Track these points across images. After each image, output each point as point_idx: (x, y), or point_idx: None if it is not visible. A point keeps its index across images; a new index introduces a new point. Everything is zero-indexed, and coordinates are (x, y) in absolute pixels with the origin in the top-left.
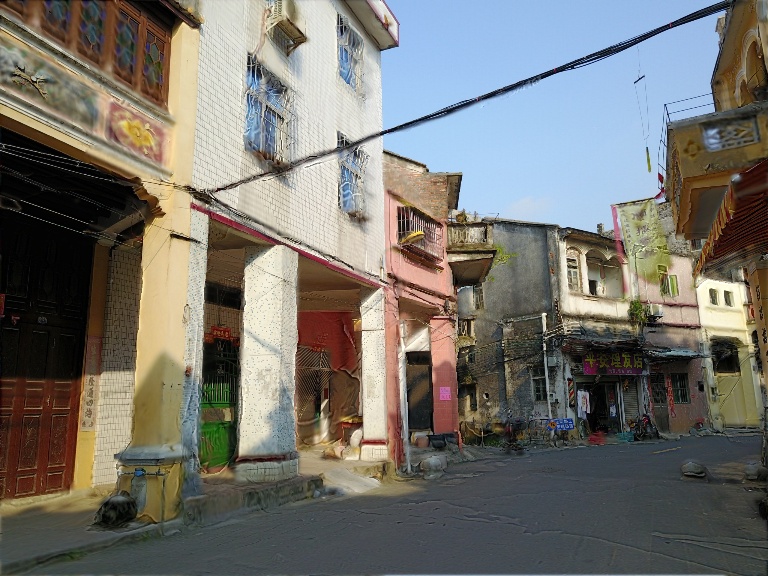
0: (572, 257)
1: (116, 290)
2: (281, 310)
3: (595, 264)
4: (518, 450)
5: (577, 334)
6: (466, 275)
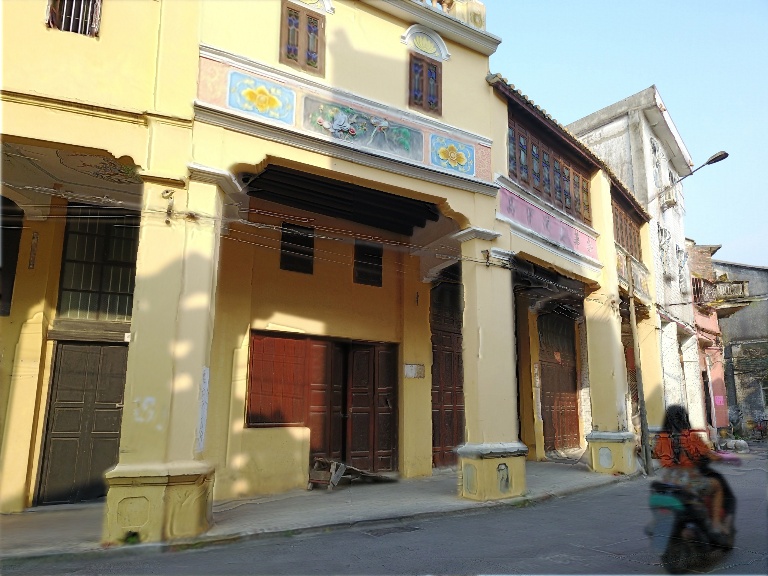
0: None
1: (582, 346)
2: (677, 357)
3: None
4: (760, 442)
5: None
6: None
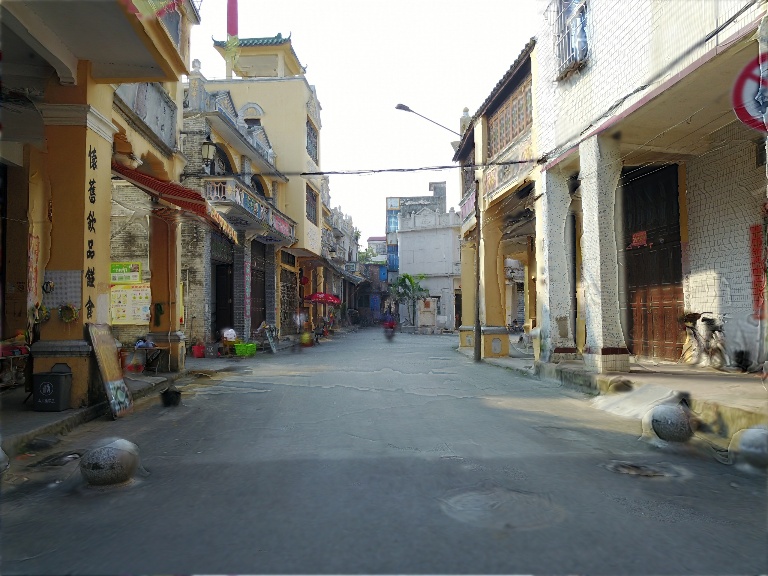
0: None
1: None
2: None
3: None
4: None
5: None
6: None
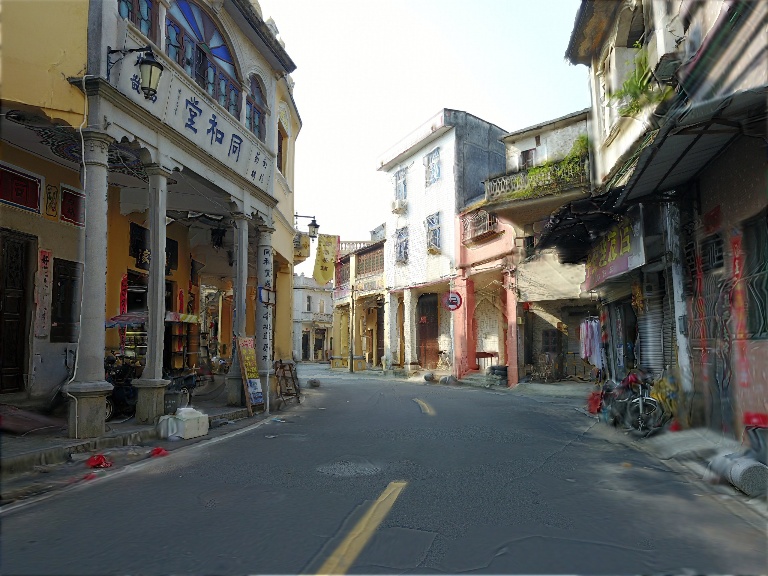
0: None
1: None
2: None
3: None
4: None
5: None
6: (575, 196)
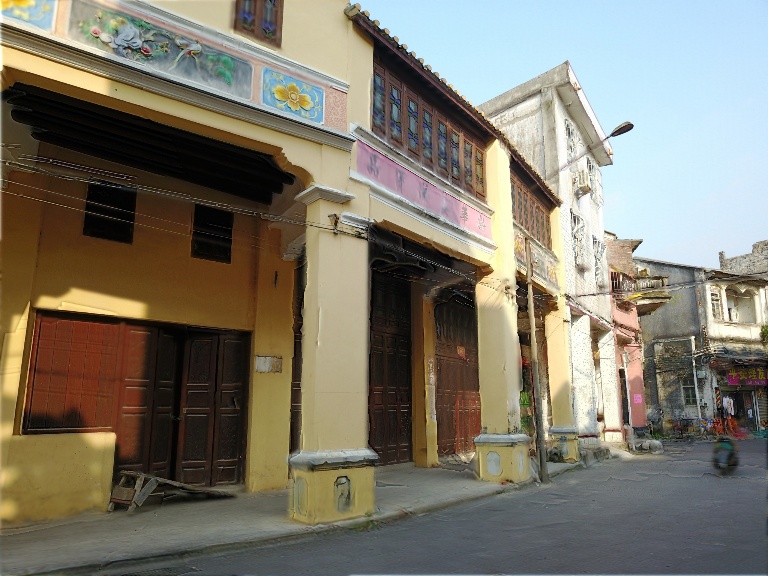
0: (714, 292)
1: None
2: (589, 353)
3: (732, 296)
4: (679, 441)
5: (721, 353)
6: None
